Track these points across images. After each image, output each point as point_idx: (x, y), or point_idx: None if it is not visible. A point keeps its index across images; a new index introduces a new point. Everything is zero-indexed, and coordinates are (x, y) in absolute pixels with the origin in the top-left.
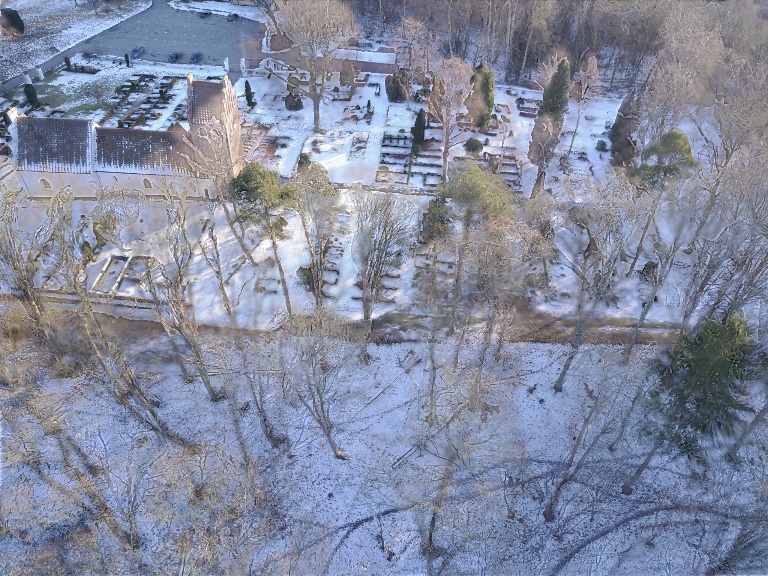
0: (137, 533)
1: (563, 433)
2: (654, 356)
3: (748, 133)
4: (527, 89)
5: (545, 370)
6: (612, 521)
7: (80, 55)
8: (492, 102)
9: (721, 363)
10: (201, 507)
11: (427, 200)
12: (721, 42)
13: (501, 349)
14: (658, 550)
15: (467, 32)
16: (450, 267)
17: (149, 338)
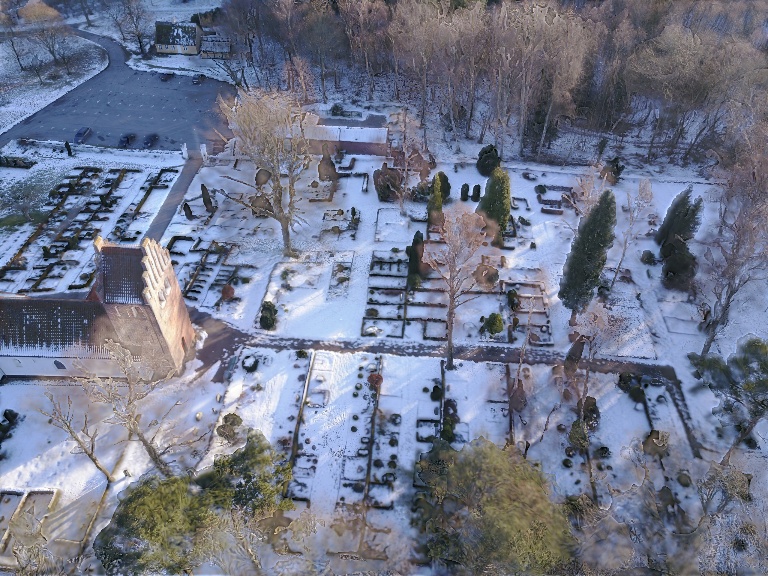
0: None
1: None
2: None
3: None
4: (548, 168)
5: None
6: None
7: (15, 142)
8: (507, 210)
9: None
10: None
11: (428, 364)
12: None
13: None
14: None
15: (472, 97)
16: None
17: None
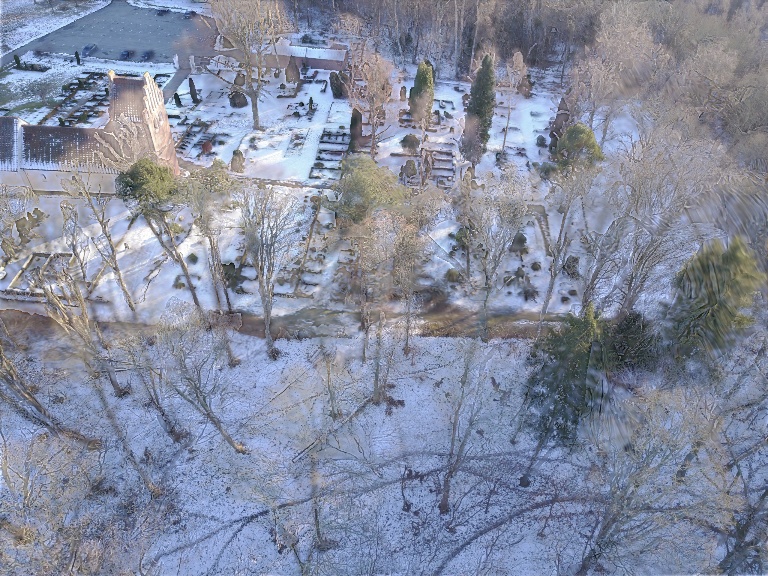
0: (30, 528)
1: None
2: None
3: (659, 128)
4: None
5: (453, 364)
6: (507, 513)
7: (31, 53)
8: (431, 98)
9: (580, 355)
10: (97, 502)
11: None
12: (649, 37)
13: (411, 343)
14: (549, 541)
15: (418, 28)
16: None
17: (61, 335)
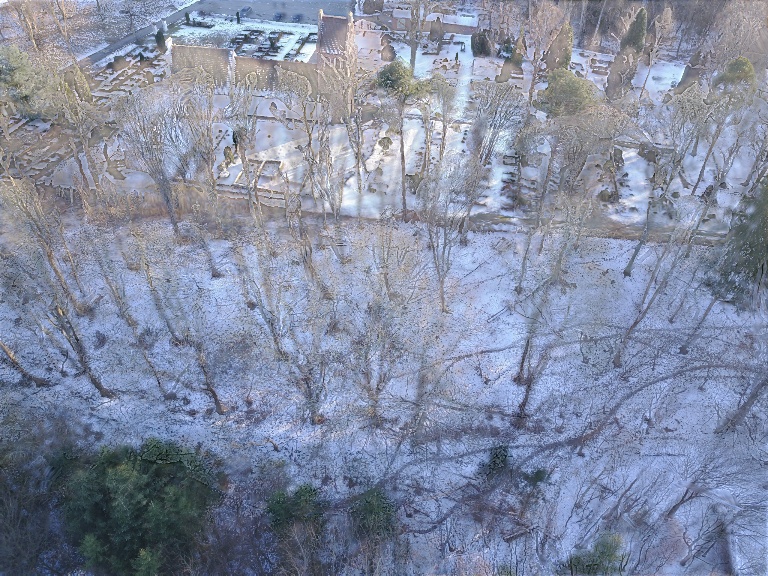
0: (287, 351)
1: (630, 307)
2: (711, 254)
3: None
4: (598, 53)
5: (616, 259)
6: (670, 371)
7: (196, 13)
8: (570, 56)
9: None
10: (335, 338)
11: None
12: None
13: (579, 241)
14: (709, 394)
15: None
16: (533, 183)
17: None
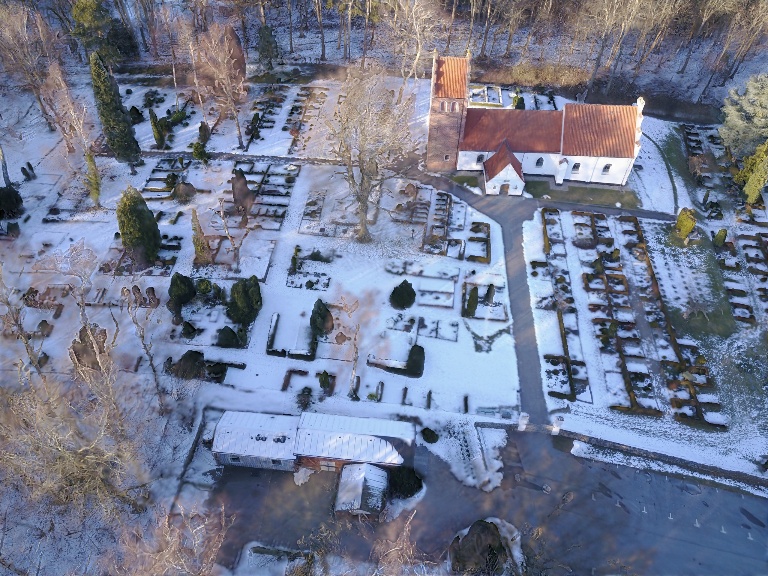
0: None
1: None
2: None
3: None
4: None
5: None
6: None
7: None
8: None
9: None
10: None
11: (256, 152)
12: None
13: None
14: None
15: None
16: (256, 107)
17: None
